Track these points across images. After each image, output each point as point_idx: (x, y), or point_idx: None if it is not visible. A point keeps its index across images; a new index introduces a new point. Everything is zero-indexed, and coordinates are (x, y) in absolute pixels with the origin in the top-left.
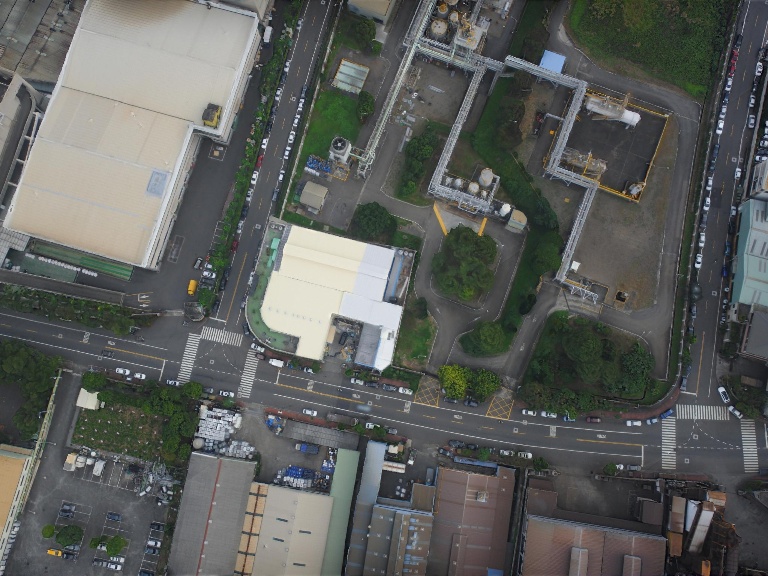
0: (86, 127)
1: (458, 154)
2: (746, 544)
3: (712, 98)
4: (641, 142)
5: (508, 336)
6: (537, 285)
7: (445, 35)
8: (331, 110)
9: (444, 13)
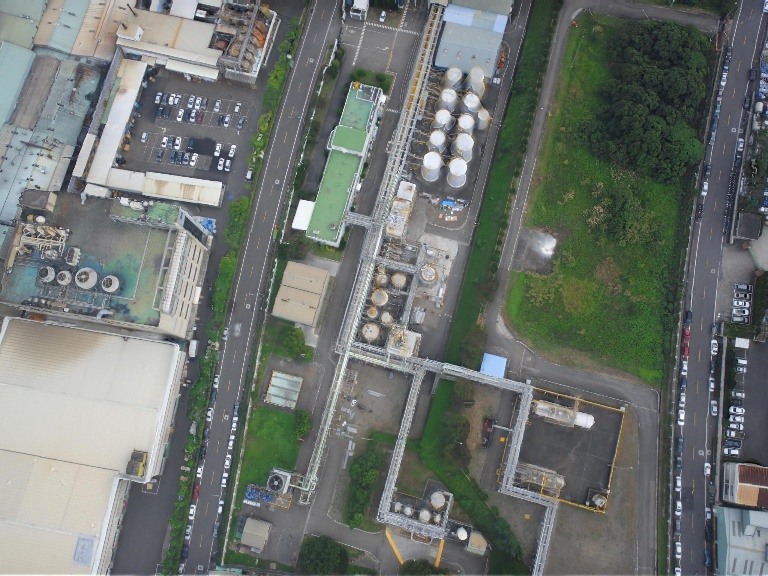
0: (4, 492)
1: (406, 468)
2: None
3: (669, 384)
4: (599, 441)
5: None
6: None
7: (378, 336)
8: (266, 429)
9: (374, 317)
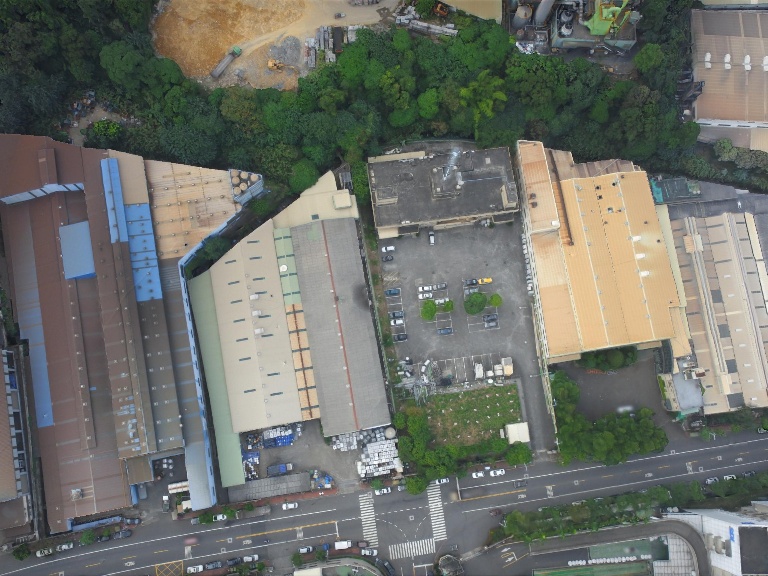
0: None
1: None
2: None
3: None
4: None
5: None
6: None
7: None
8: None
9: None
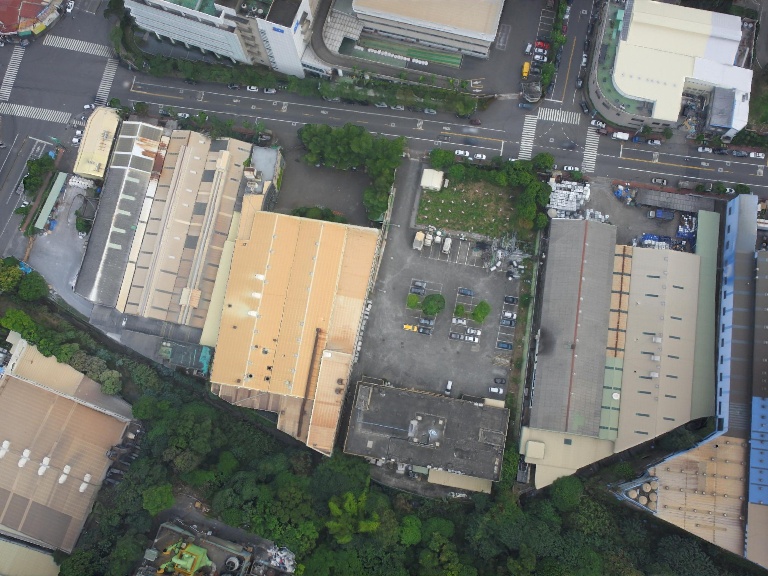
0: None
1: None
2: None
3: None
4: None
5: None
6: None
7: None
8: None
9: None
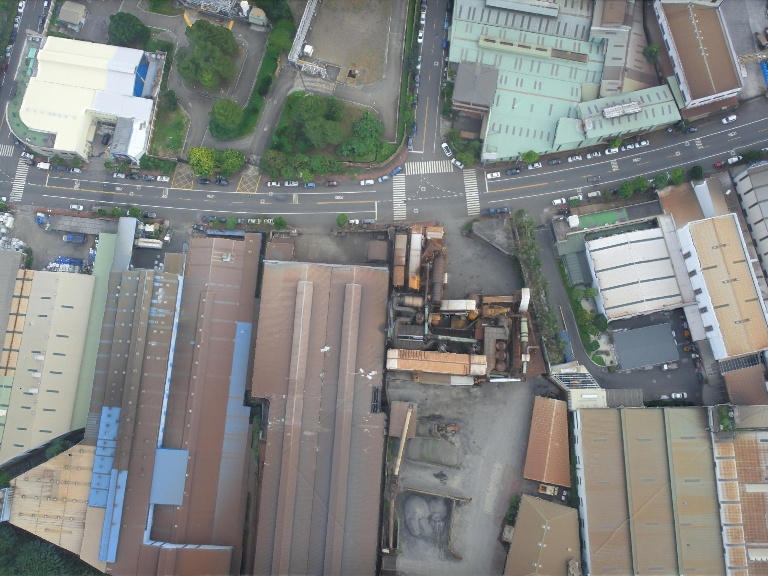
0: None
1: None
2: (471, 278)
3: None
4: None
5: (252, 118)
6: (275, 70)
7: None
8: None
9: None
